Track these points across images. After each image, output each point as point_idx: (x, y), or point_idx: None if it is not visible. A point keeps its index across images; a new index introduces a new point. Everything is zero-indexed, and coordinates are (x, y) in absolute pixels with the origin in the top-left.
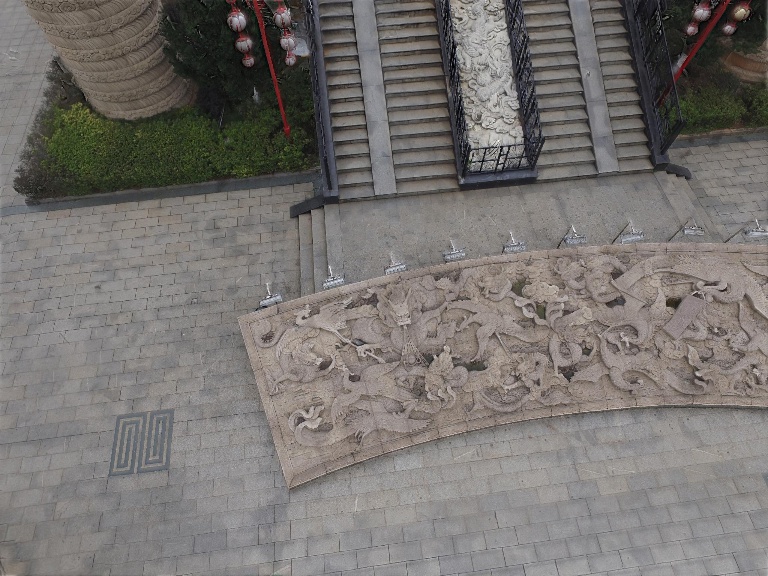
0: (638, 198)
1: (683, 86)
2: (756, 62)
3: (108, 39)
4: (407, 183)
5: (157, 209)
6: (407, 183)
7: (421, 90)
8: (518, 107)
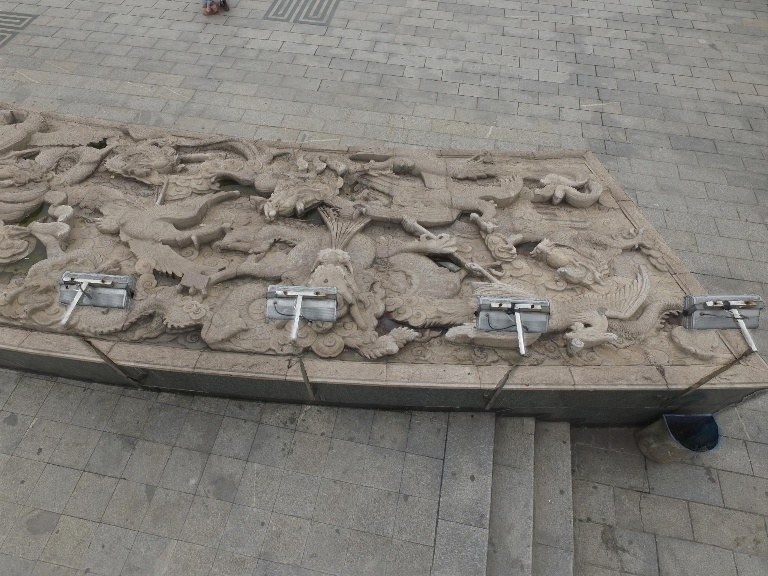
0: None
1: None
2: None
3: None
4: None
5: None
6: None
7: None
8: None
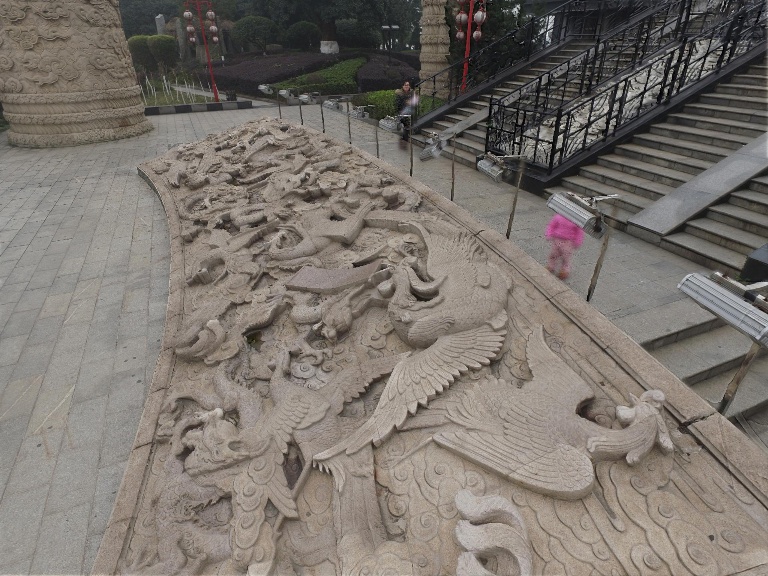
0: (631, 266)
1: None
2: None
3: (436, 30)
4: None
5: (367, 127)
6: None
7: (559, 98)
8: None
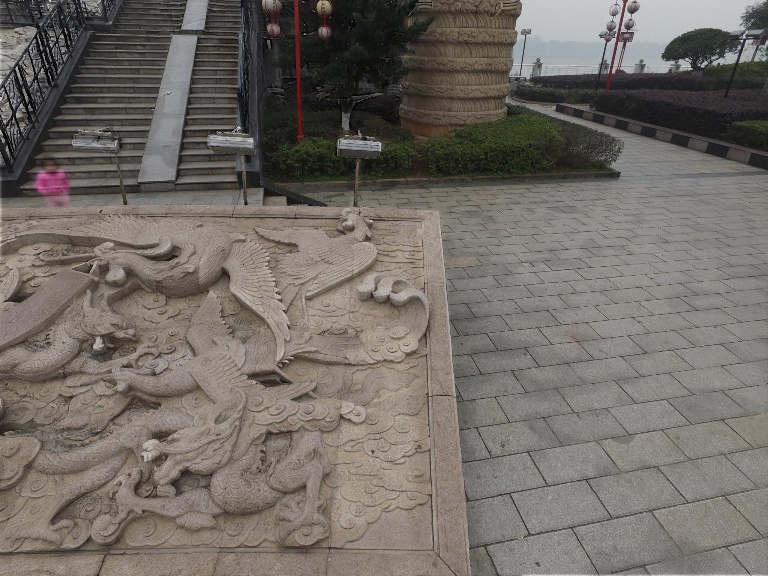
0: None
1: (335, 134)
2: (437, 126)
3: None
4: None
5: None
6: None
7: None
8: (31, 109)
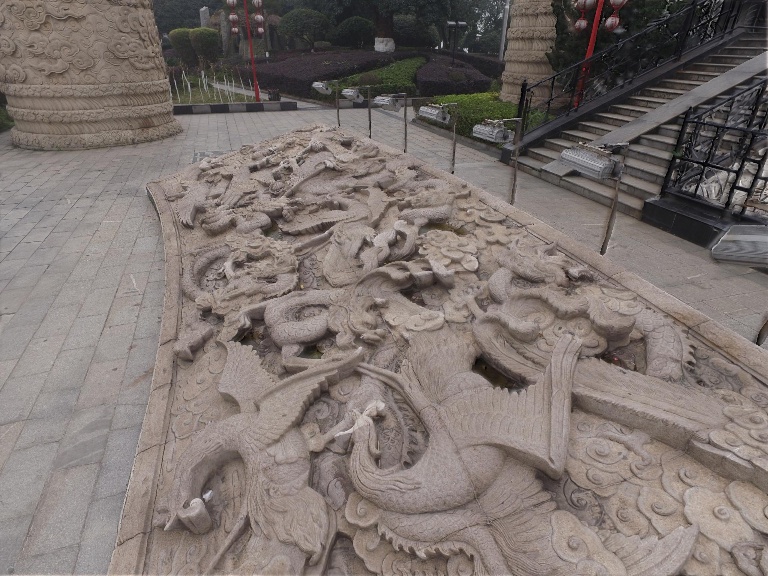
0: None
1: None
2: None
3: (532, 21)
4: (591, 181)
5: (437, 139)
6: (591, 181)
7: (759, 114)
8: None
